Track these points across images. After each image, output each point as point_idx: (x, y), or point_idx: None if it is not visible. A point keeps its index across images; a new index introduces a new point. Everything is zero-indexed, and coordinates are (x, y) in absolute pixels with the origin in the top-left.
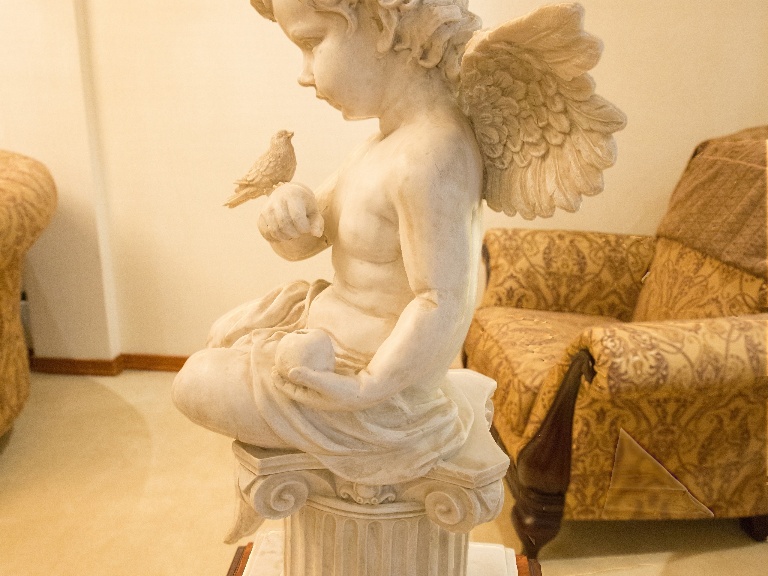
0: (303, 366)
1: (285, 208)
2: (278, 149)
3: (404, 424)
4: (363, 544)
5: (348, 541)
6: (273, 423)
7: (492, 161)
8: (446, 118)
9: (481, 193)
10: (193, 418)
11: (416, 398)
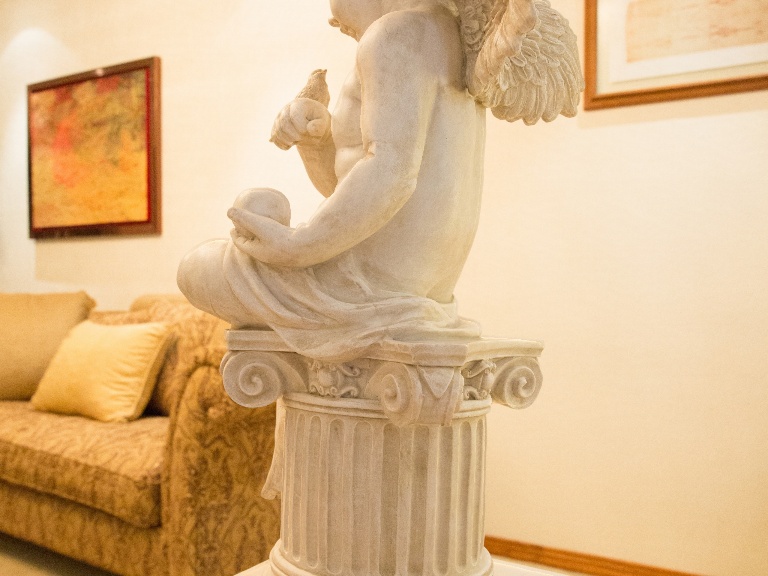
0: (244, 209)
1: (287, 110)
2: (311, 83)
3: (362, 302)
4: (325, 445)
5: (314, 443)
6: (233, 284)
7: (471, 48)
8: (422, 8)
9: (458, 78)
10: (186, 293)
11: (383, 283)
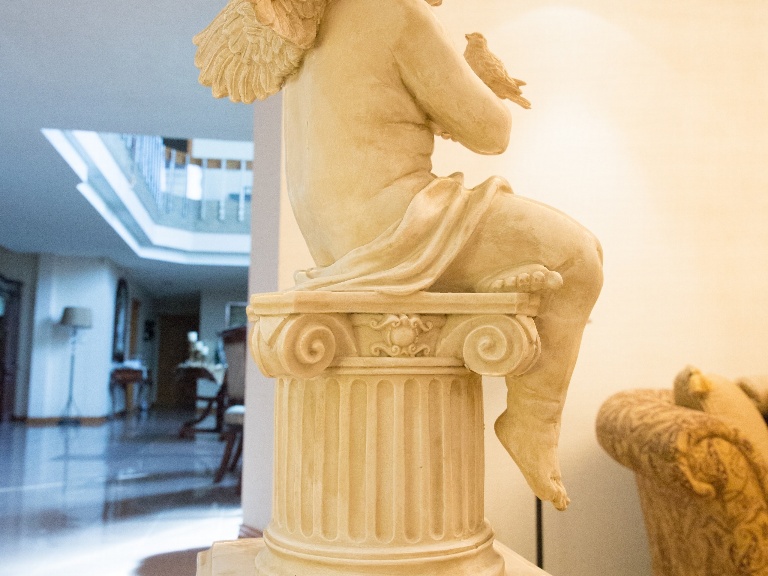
0: None
1: None
2: None
3: None
4: None
5: None
6: None
7: None
8: None
9: None
10: None
11: None
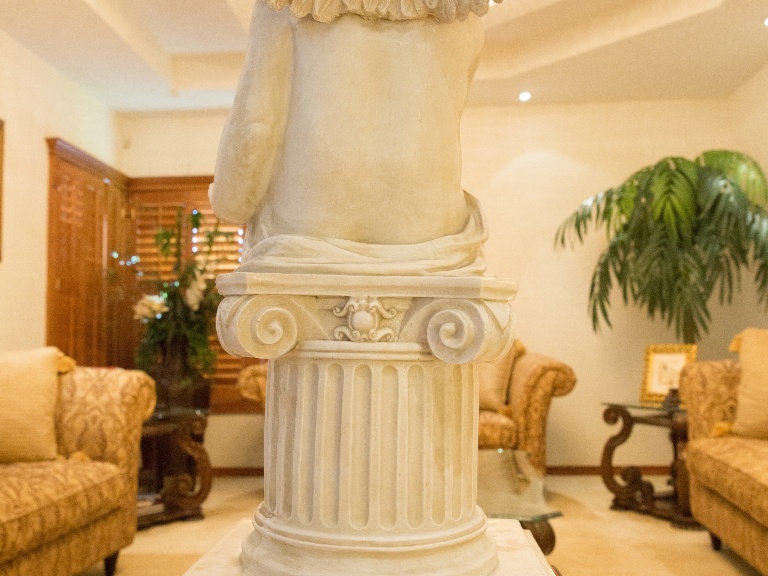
0: None
1: None
2: None
3: None
4: None
5: None
6: None
7: None
8: None
9: None
10: None
11: (280, 227)
